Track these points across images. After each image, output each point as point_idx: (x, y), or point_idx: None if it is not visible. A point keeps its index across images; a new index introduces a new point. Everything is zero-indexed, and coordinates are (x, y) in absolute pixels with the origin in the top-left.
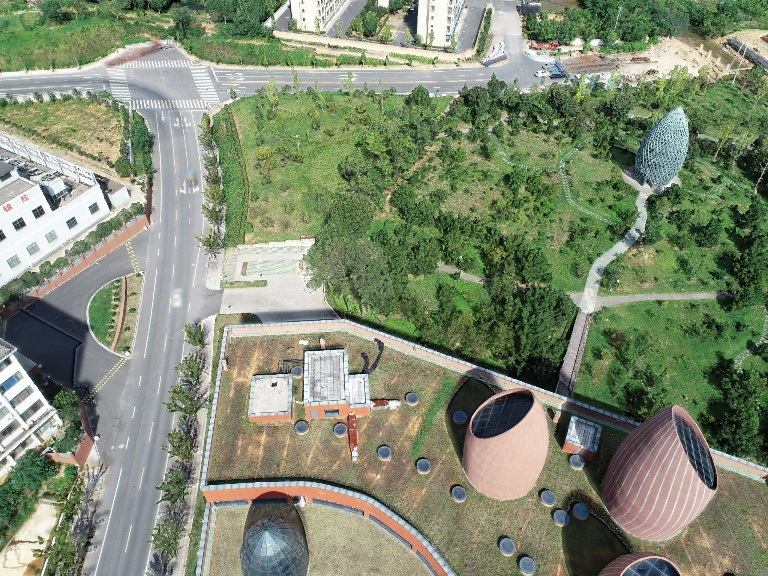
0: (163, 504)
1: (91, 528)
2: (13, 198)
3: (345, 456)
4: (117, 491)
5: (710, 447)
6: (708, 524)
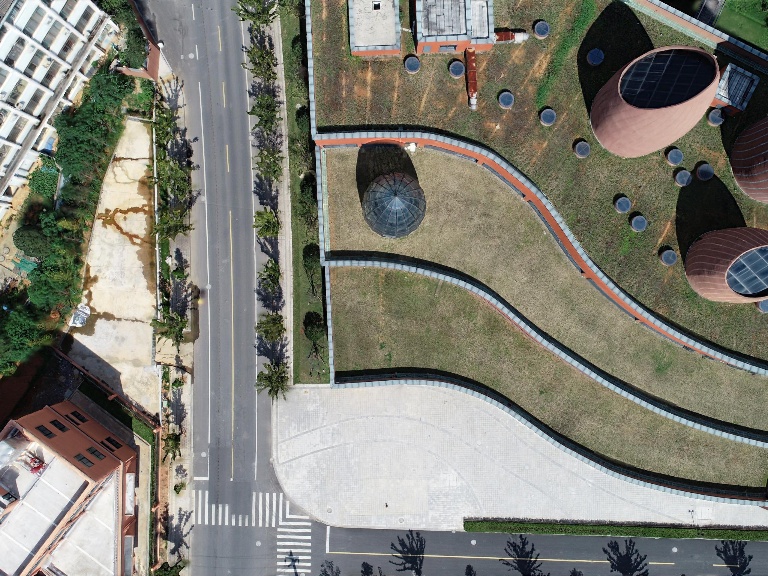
0: (253, 124)
1: (187, 147)
2: None
3: (462, 101)
4: (202, 108)
5: None
6: None
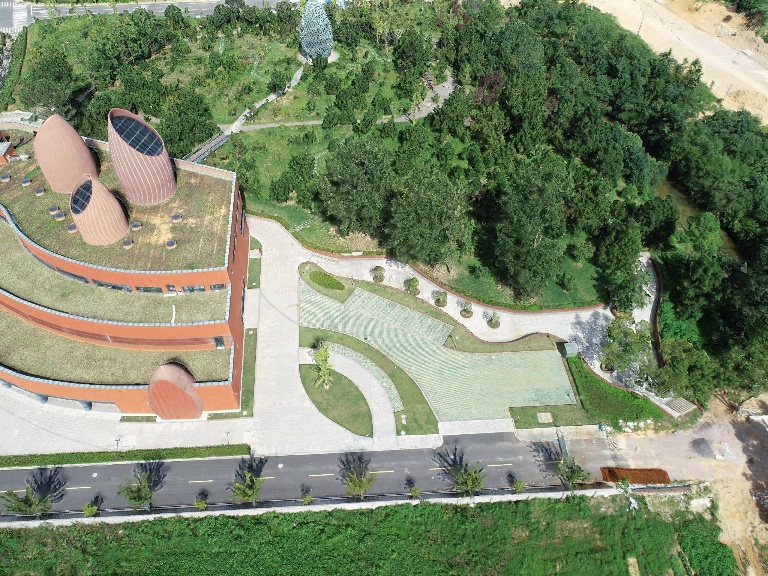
0: None
1: None
2: None
3: None
4: None
5: (270, 199)
6: (183, 198)
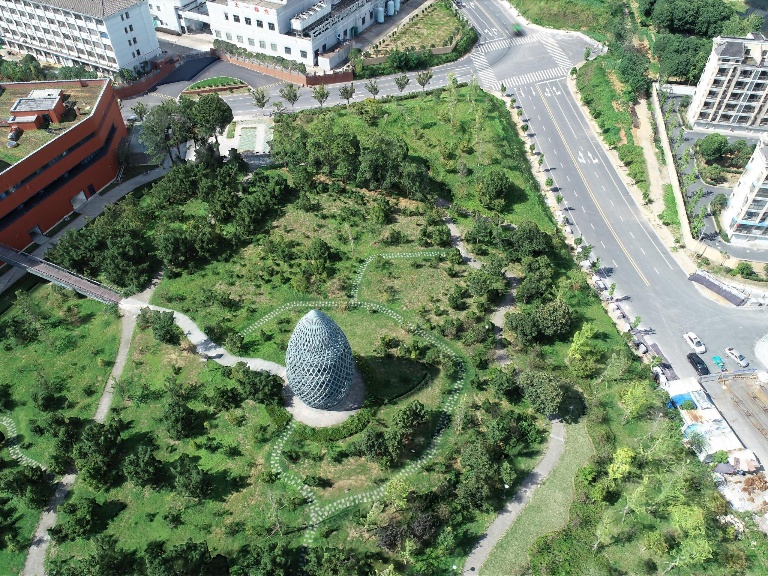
0: None
1: None
2: (261, 6)
3: None
4: None
5: None
6: None
